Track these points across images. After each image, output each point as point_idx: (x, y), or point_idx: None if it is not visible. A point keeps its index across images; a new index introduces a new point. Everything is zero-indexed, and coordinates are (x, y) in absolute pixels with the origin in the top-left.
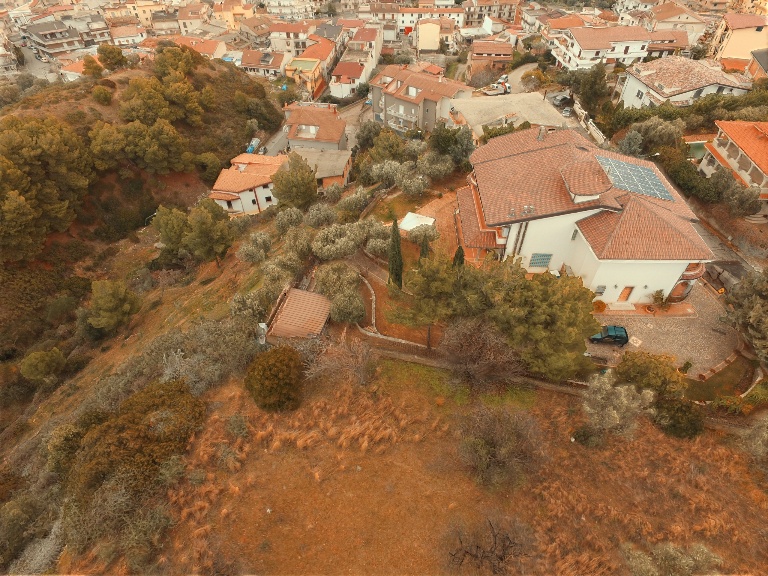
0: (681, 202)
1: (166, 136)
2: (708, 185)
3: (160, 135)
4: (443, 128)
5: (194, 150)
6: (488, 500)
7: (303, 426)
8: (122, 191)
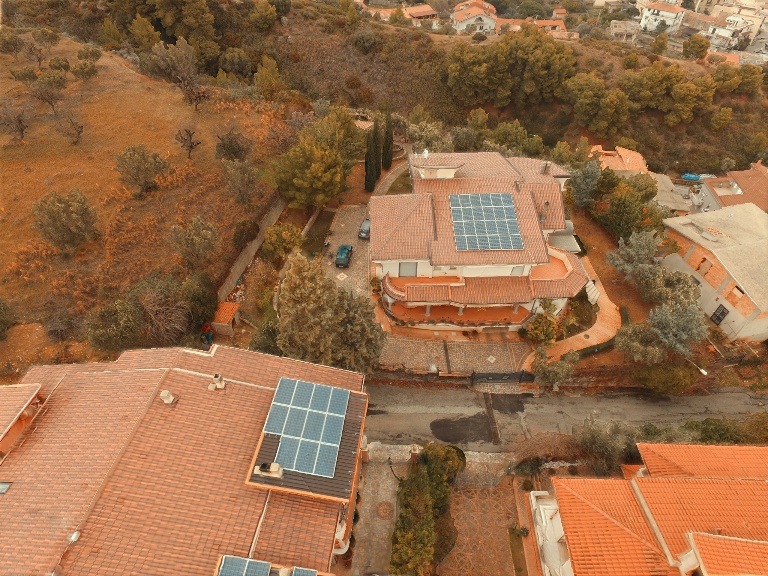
0: (462, 259)
1: (604, 100)
2: (653, 430)
3: (603, 98)
4: (597, 159)
5: (637, 136)
6: (220, 162)
7: (272, 121)
8: (554, 118)
